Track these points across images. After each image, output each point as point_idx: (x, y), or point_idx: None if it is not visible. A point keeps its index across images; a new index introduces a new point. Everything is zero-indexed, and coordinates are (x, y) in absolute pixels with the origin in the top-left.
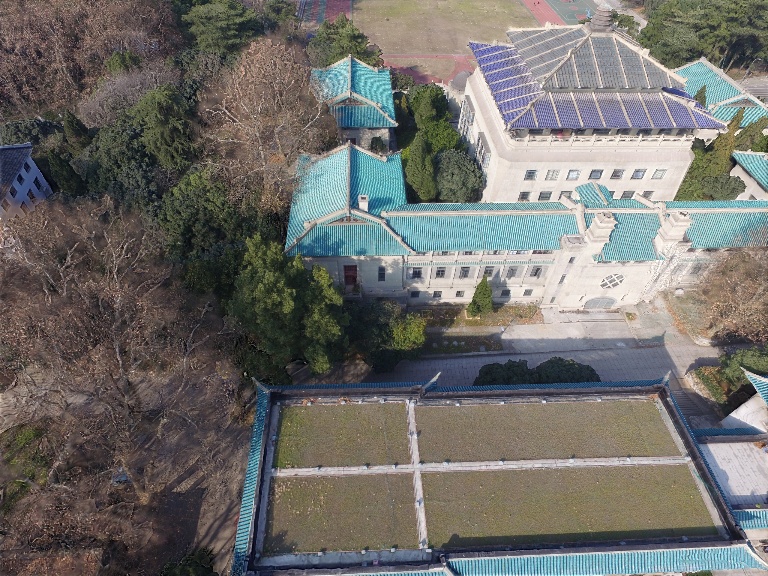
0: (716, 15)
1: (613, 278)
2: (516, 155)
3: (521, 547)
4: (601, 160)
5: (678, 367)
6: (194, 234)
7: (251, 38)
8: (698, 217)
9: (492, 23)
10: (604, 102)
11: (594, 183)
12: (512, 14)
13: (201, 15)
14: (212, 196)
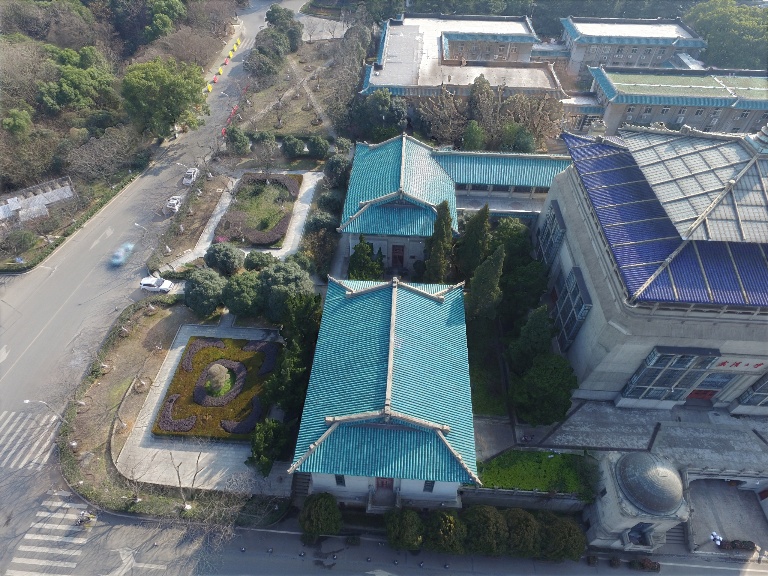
0: None
1: None
2: None
3: (678, 75)
4: None
5: None
6: None
7: None
8: None
9: None
10: None
11: None
12: None
13: None
14: None
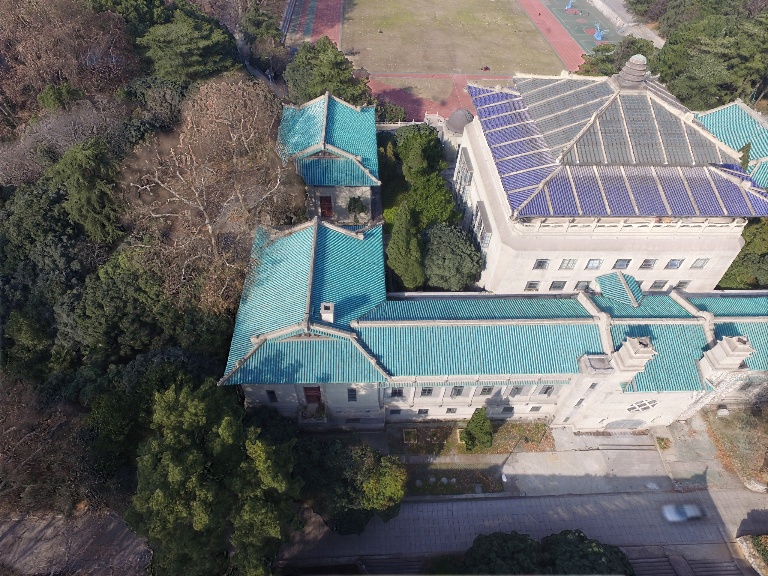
0: (748, 44)
1: (644, 403)
2: (524, 242)
3: None
4: (629, 249)
5: (726, 524)
6: (122, 330)
7: (218, 64)
8: (752, 328)
9: (494, 37)
10: (636, 179)
11: (619, 274)
12: (515, 27)
13: (159, 38)
14: (144, 284)
